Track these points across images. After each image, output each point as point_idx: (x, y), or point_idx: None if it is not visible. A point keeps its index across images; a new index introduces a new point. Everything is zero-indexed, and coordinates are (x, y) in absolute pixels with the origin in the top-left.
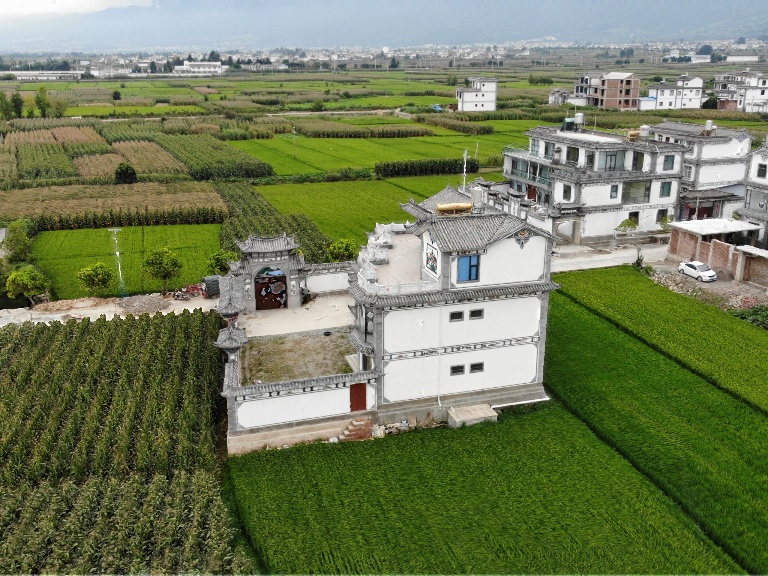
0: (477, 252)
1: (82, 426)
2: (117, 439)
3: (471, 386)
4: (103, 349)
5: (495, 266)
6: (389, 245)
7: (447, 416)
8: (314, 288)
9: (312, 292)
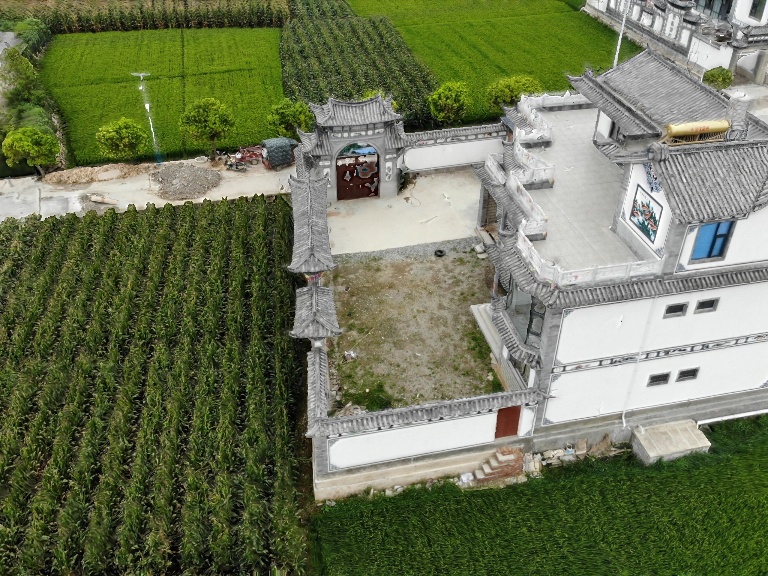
0: (733, 216)
1: (103, 442)
2: (153, 487)
3: (673, 397)
4: (132, 278)
5: (755, 236)
6: (546, 141)
7: (631, 437)
8: (414, 164)
9: (411, 170)
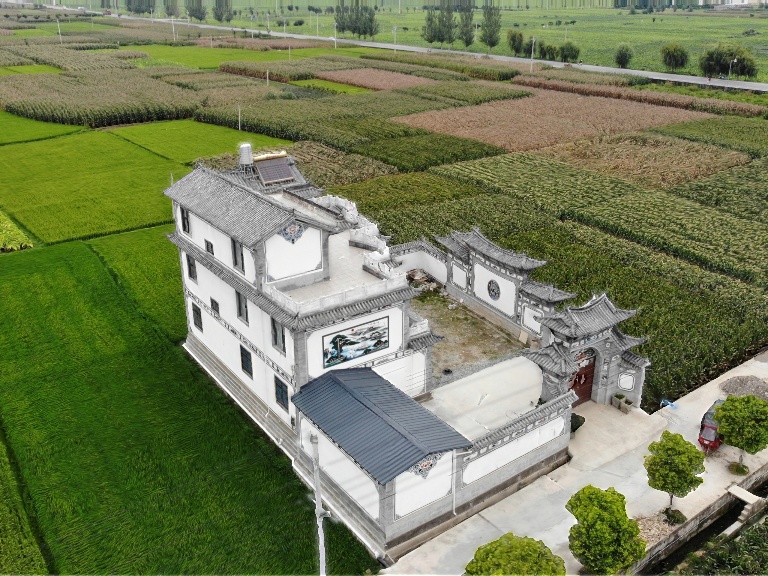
0: None
1: None
2: None
3: None
4: None
5: None
6: None
7: None
8: None
9: None
